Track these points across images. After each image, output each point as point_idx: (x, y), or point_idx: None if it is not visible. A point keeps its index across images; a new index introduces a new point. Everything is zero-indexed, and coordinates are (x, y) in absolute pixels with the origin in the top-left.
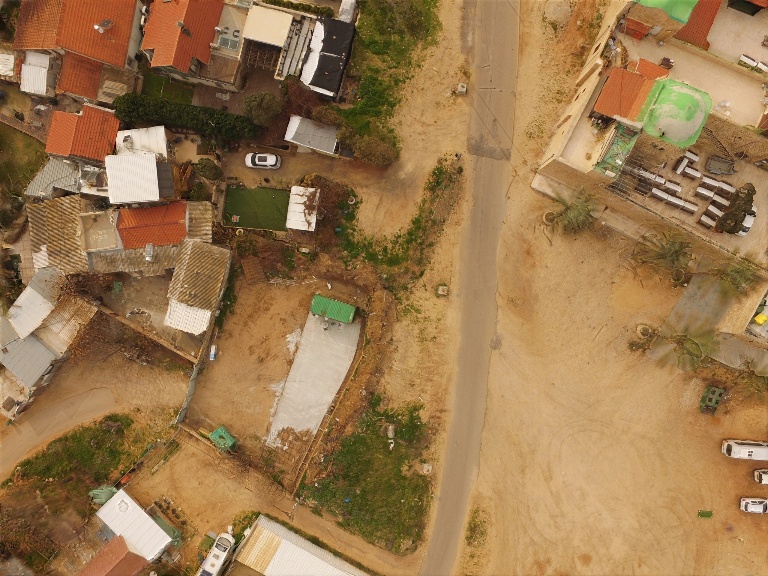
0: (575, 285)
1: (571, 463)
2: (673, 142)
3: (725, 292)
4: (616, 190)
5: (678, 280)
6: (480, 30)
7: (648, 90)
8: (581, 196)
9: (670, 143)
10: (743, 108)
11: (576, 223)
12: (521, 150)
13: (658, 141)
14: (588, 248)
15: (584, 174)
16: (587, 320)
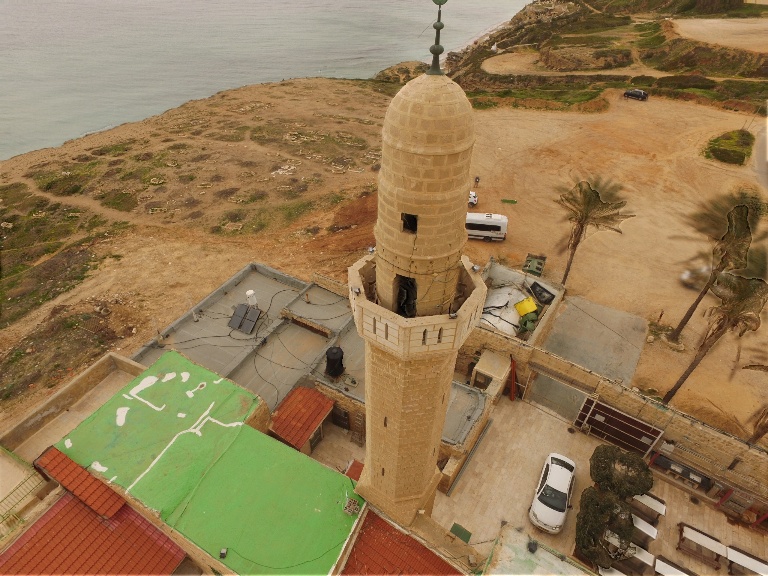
0: None
1: (684, 244)
2: None
3: None
4: None
5: None
6: None
7: None
8: None
9: None
10: None
11: None
12: None
13: None
14: None
15: None
16: None
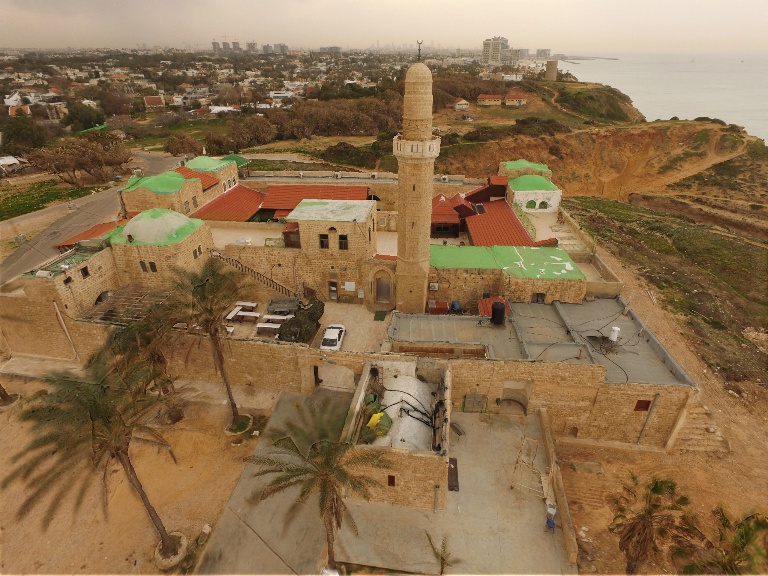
0: (26, 499)
1: None
2: (149, 244)
3: (334, 428)
4: (95, 319)
5: (241, 430)
6: (3, 276)
7: (124, 223)
8: (76, 366)
9: (146, 246)
10: (270, 243)
11: (56, 397)
12: (1, 344)
13: (138, 253)
14: (71, 427)
15: (29, 302)
16: (35, 571)
